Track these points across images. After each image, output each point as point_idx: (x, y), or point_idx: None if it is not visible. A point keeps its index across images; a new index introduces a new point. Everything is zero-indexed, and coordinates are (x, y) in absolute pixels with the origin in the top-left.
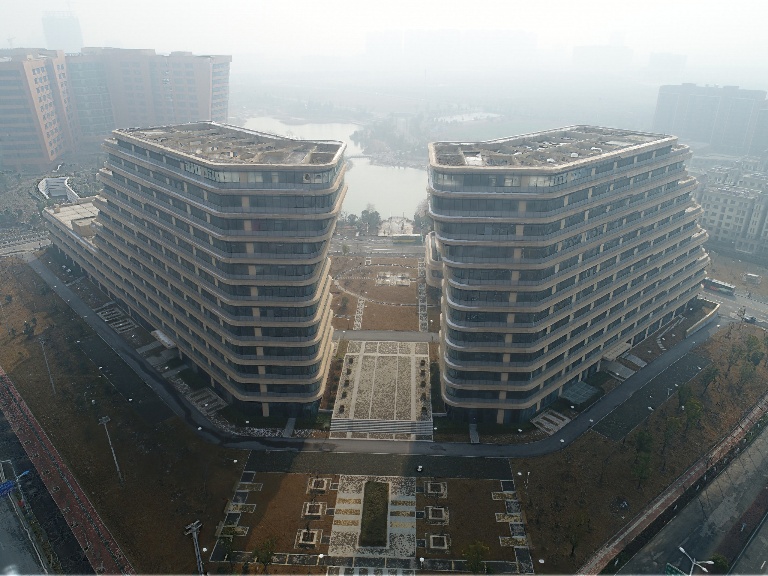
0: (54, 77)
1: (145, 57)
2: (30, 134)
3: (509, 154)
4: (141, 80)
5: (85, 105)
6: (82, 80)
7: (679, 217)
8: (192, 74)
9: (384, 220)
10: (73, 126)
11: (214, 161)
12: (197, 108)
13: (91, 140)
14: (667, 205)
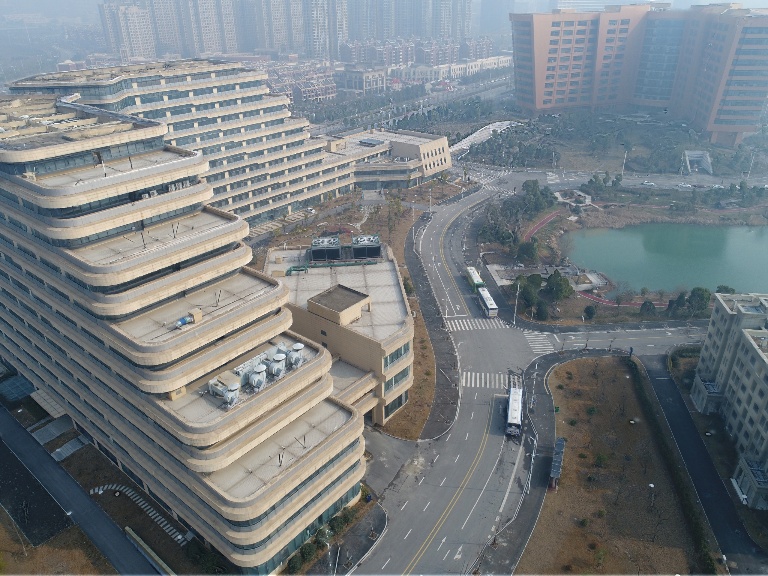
0: (598, 31)
1: (703, 15)
2: (530, 81)
3: (16, 112)
4: (694, 42)
5: (647, 65)
6: (654, 38)
7: (87, 312)
8: (724, 39)
9: (585, 269)
10: (611, 83)
11: (49, 73)
12: (714, 83)
13: (636, 102)
14: (52, 266)
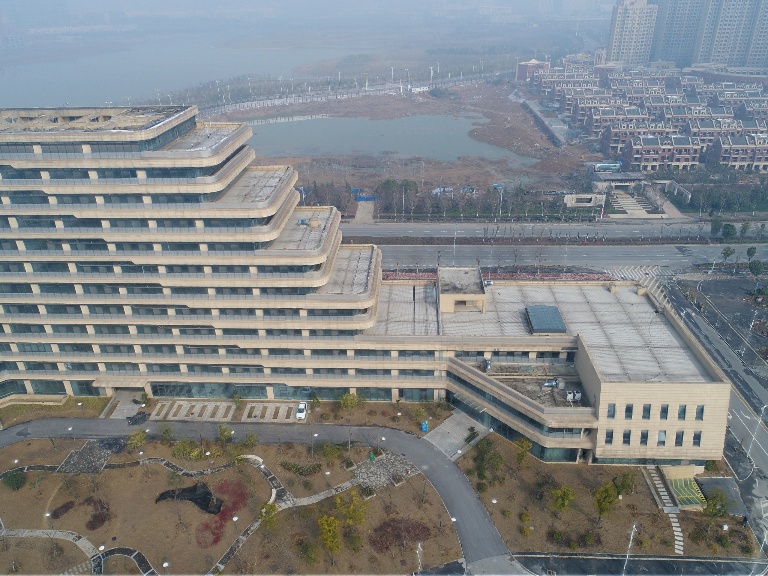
0: None
1: None
2: None
3: None
4: None
5: None
6: None
7: None
8: None
9: None
10: None
11: None
12: None
13: None
14: None
